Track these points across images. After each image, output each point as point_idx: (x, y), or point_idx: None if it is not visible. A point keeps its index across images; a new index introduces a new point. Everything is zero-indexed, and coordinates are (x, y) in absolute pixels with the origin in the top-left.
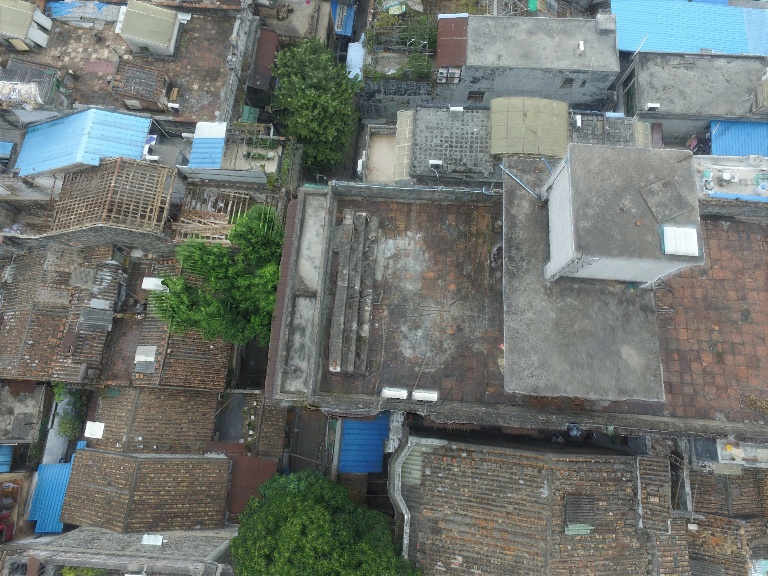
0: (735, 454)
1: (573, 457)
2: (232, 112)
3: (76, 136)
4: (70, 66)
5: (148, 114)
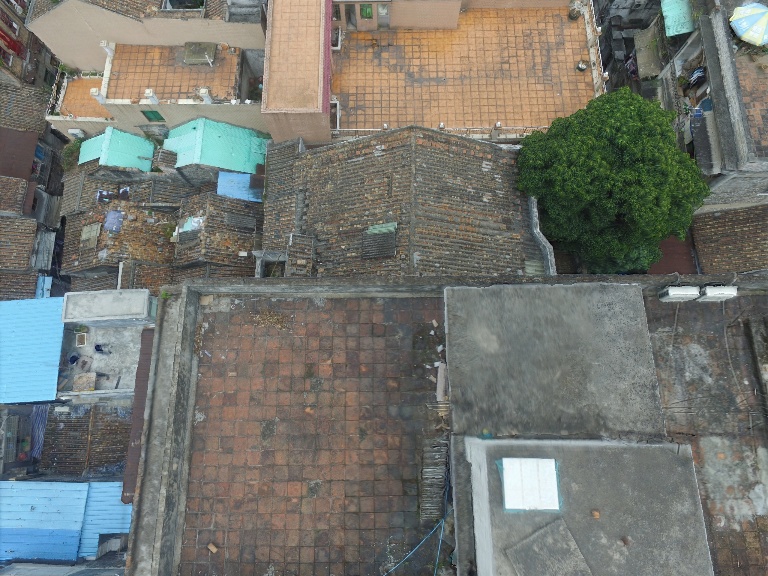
0: None
1: None
2: None
3: None
4: None
5: None
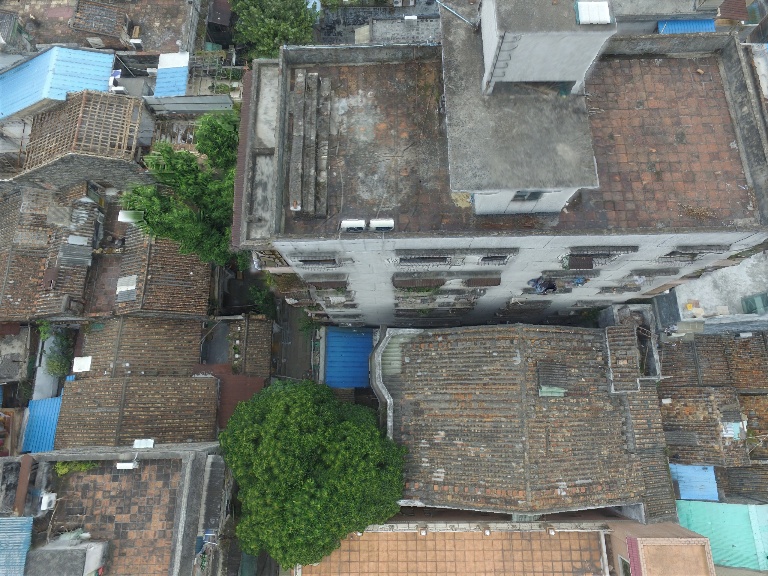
0: (696, 313)
1: (543, 328)
2: (194, 45)
3: (41, 75)
4: (31, 13)
5: (111, 50)
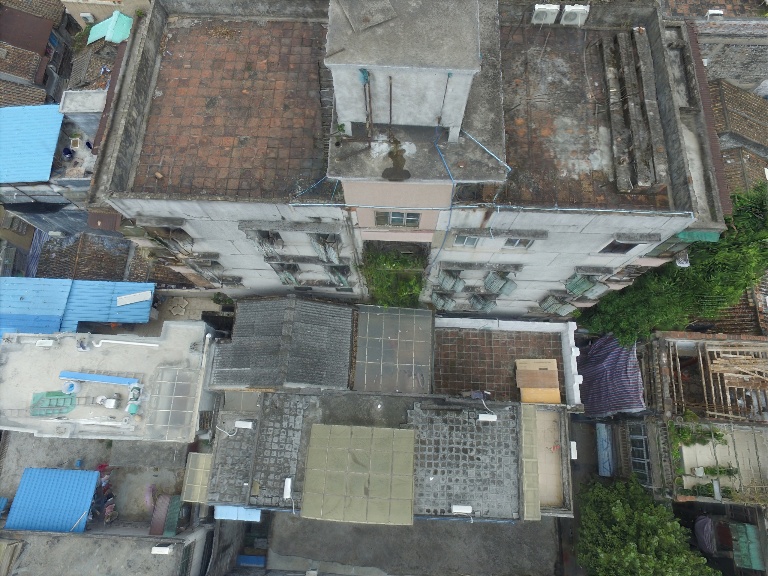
0: None
1: None
2: None
3: None
4: None
5: None
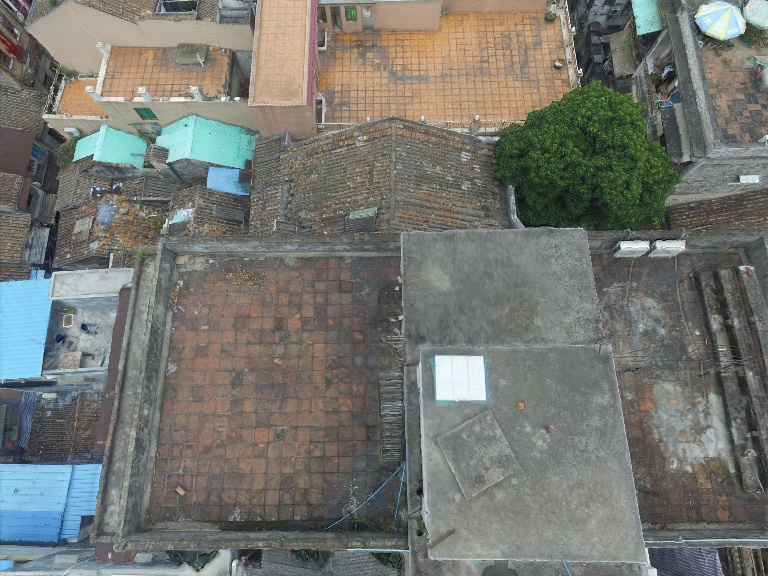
0: None
1: None
2: None
3: None
4: None
5: None
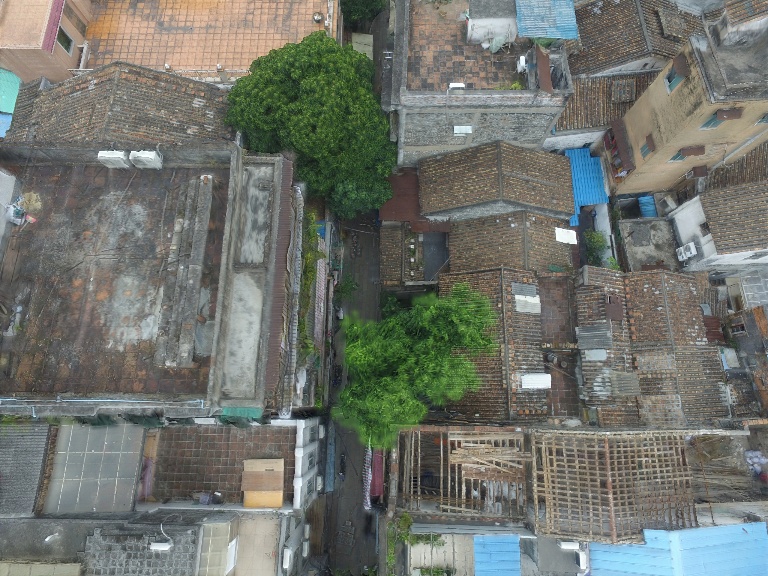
0: None
1: None
2: None
3: None
4: None
5: None
